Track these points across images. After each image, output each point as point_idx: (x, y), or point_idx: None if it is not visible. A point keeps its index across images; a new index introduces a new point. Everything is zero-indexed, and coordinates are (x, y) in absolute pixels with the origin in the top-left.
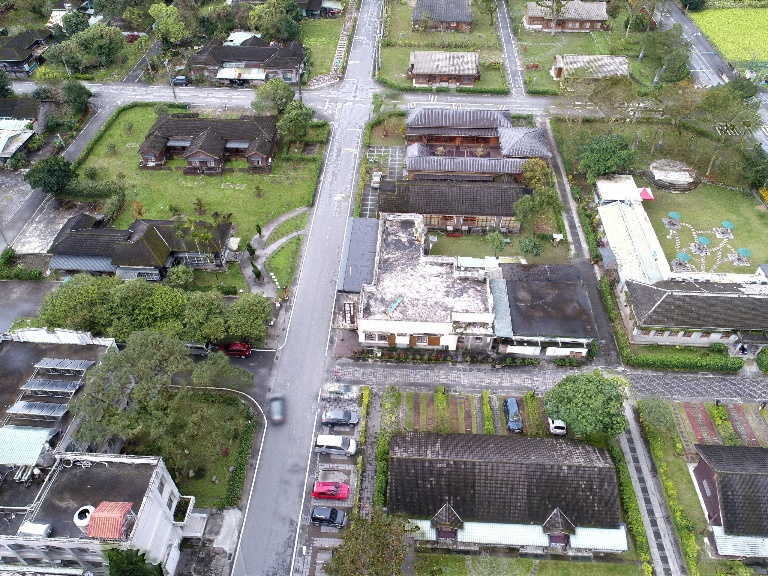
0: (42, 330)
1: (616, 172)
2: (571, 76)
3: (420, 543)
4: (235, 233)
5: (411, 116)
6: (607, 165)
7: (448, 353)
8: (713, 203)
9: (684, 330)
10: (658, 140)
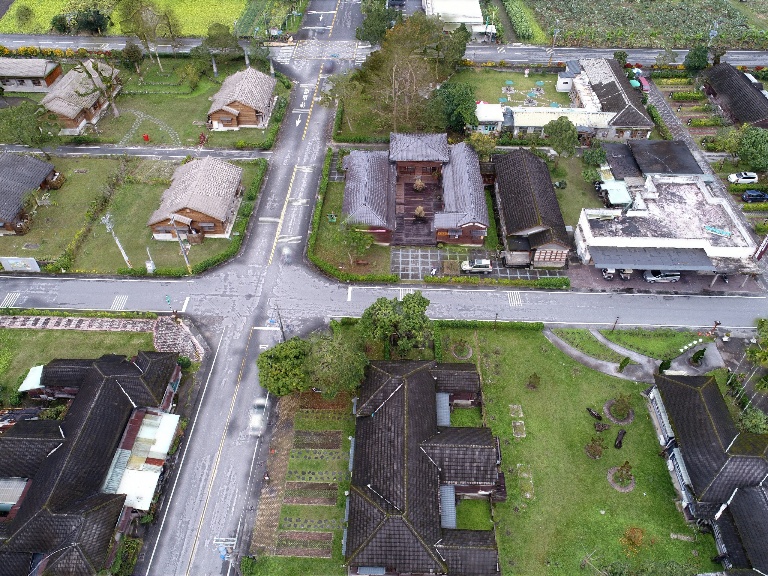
0: None
1: None
2: (322, 92)
3: None
4: None
5: (370, 218)
6: None
7: None
8: None
9: None
10: None
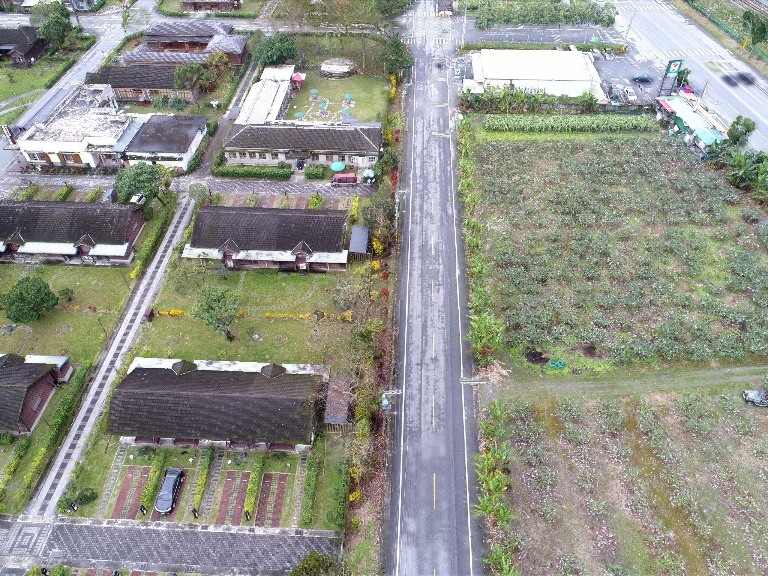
0: None
1: (296, 67)
2: None
3: (2, 259)
4: None
5: (150, 27)
6: (268, 55)
7: (90, 169)
8: (355, 86)
9: (255, 151)
10: (347, 47)
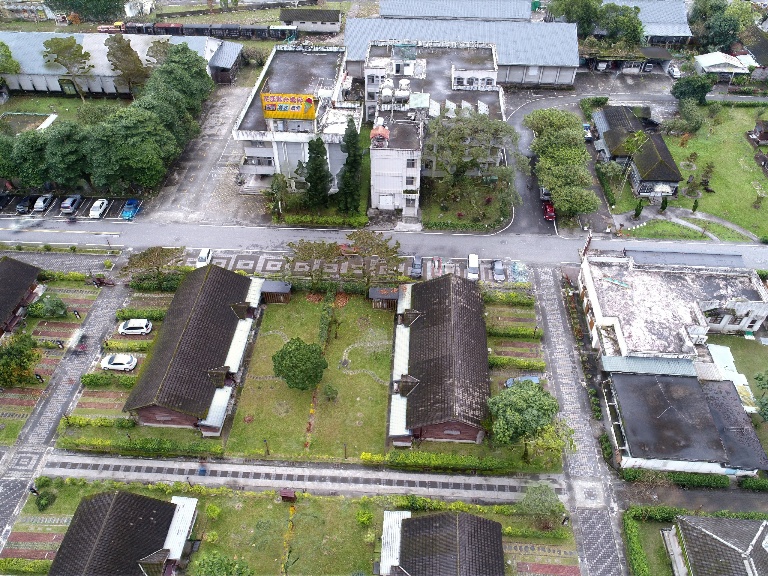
0: (502, 93)
1: None
2: None
3: None
4: (689, 198)
5: None
6: None
7: (588, 343)
8: None
9: None
10: None
